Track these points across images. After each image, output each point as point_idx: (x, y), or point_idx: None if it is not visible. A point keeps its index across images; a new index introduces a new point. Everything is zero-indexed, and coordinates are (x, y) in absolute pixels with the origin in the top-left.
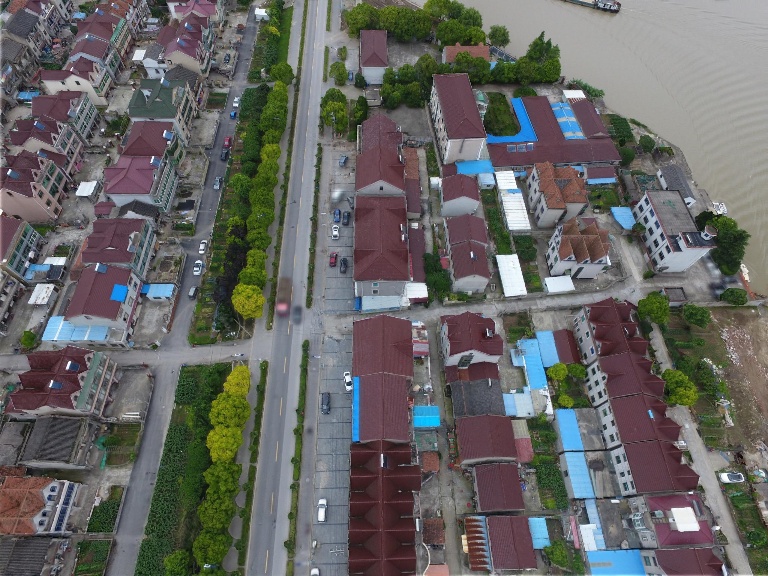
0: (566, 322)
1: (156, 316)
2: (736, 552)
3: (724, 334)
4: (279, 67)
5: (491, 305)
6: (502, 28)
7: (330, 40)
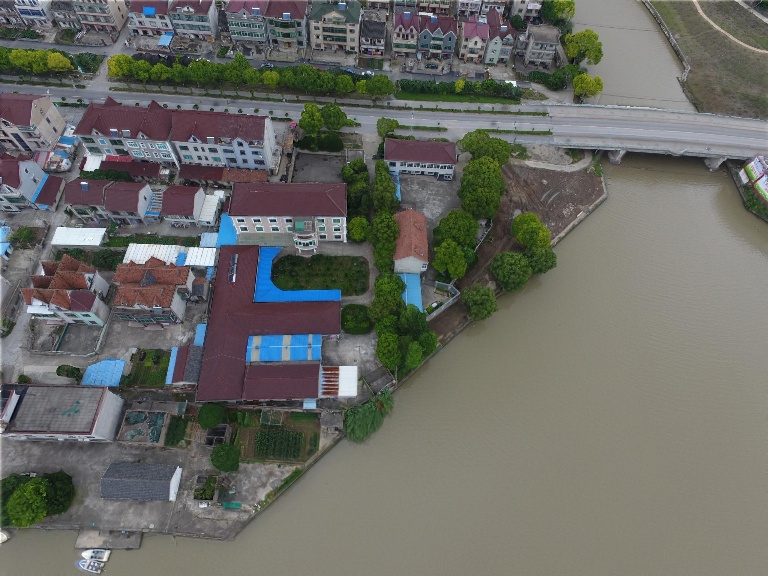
0: (14, 279)
1: (151, 44)
2: None
3: None
4: (377, 76)
5: (63, 222)
6: (486, 300)
7: (461, 133)
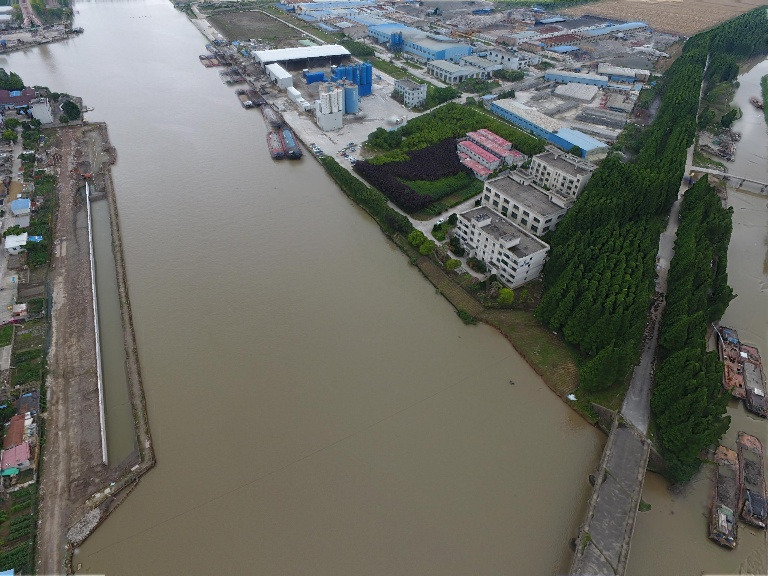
0: None
1: None
2: (17, 164)
3: (58, 131)
4: None
5: None
6: None
7: None
